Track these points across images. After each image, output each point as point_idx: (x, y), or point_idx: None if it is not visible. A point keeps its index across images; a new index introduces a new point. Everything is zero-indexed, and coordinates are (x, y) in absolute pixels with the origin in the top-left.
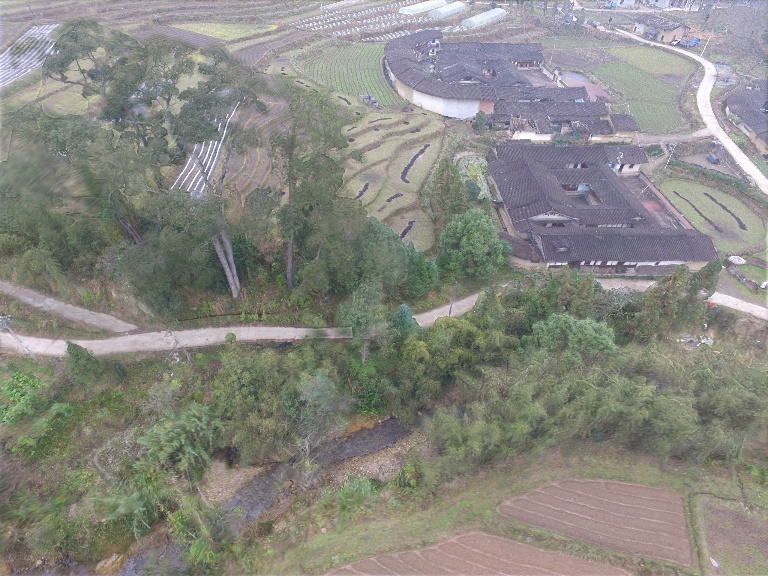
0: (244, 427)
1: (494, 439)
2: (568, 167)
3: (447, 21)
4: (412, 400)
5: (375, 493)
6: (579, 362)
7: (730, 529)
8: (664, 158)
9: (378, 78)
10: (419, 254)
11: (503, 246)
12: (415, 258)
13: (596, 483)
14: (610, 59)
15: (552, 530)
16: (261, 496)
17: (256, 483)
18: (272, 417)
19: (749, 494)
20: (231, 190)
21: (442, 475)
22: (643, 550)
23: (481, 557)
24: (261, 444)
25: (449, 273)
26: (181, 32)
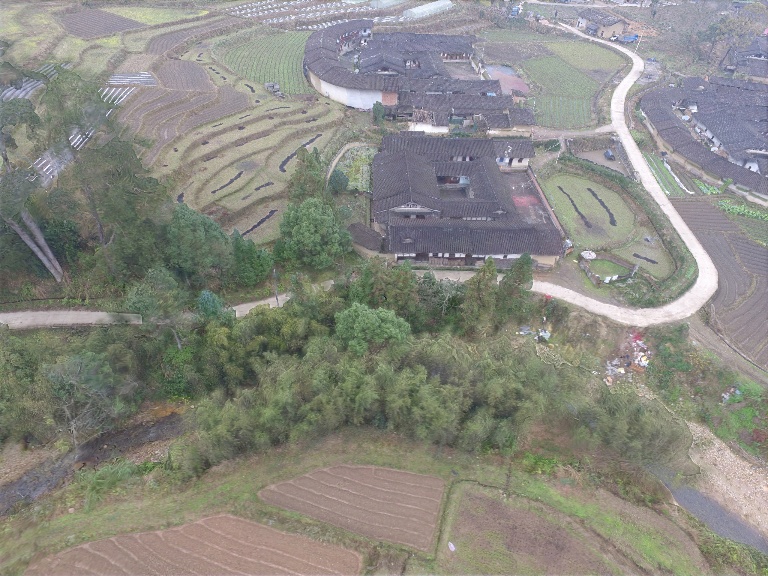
0: (17, 409)
1: (247, 424)
2: (457, 160)
3: (388, 11)
4: (220, 386)
5: (141, 475)
6: (361, 350)
7: (480, 515)
8: None
9: (296, 67)
10: (248, 242)
11: (343, 236)
12: (243, 246)
13: (366, 469)
14: (544, 53)
15: (305, 514)
16: (48, 477)
17: (47, 465)
18: (46, 399)
19: (513, 482)
20: (37, 173)
21: (207, 459)
22: (386, 534)
23: (219, 538)
24: (35, 426)
25: (286, 262)
26: (108, 16)
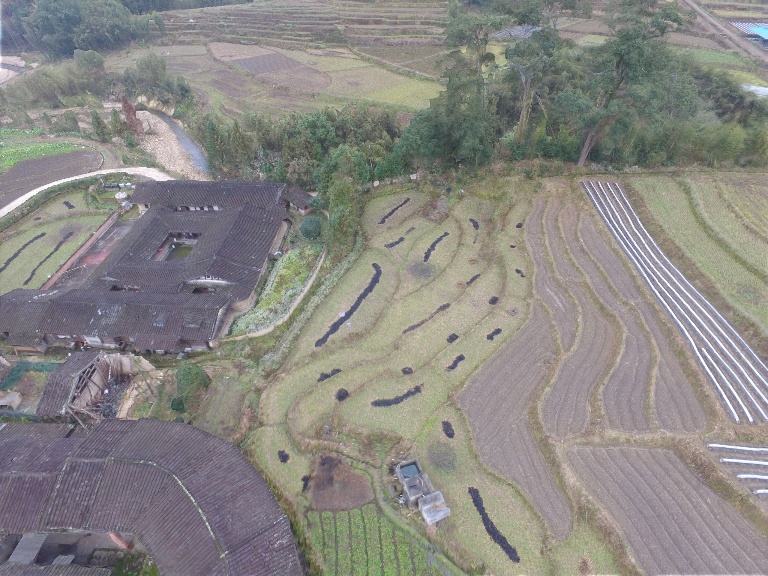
0: None
1: None
2: None
3: None
4: None
5: None
6: None
7: None
8: None
9: None
10: None
11: None
12: None
13: None
14: None
15: None
16: None
17: None
18: None
19: None
20: None
21: None
22: None
23: None
24: None
25: None
26: None
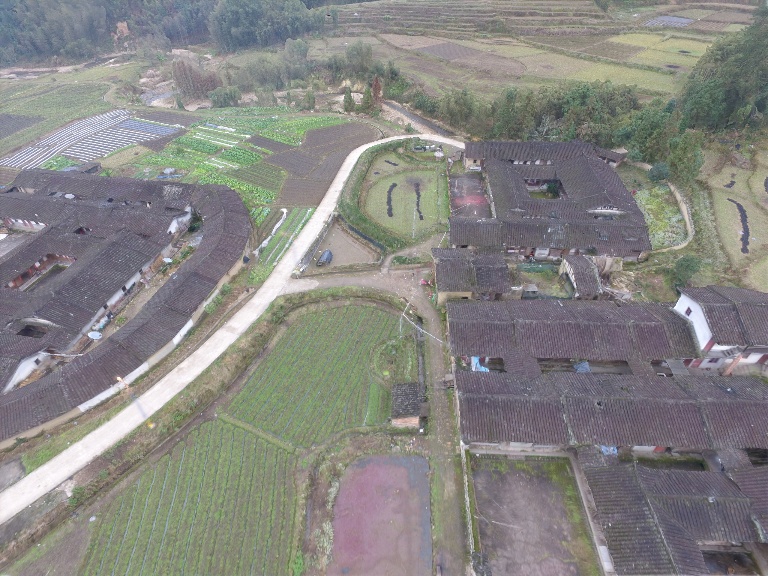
0: None
1: None
2: None
3: None
4: None
5: None
6: None
7: None
8: (399, 253)
9: None
10: None
11: None
12: None
13: None
14: None
15: None
16: None
17: None
18: None
19: None
20: None
21: None
22: None
23: None
24: None
25: None
26: None
